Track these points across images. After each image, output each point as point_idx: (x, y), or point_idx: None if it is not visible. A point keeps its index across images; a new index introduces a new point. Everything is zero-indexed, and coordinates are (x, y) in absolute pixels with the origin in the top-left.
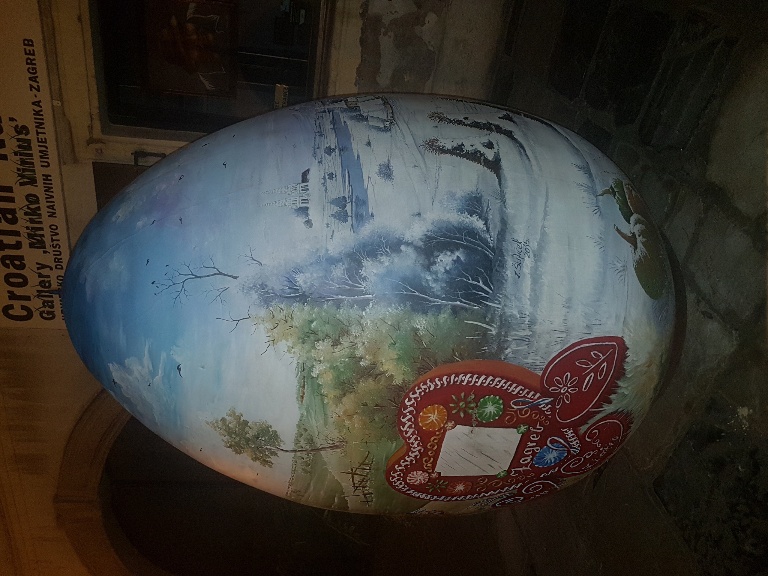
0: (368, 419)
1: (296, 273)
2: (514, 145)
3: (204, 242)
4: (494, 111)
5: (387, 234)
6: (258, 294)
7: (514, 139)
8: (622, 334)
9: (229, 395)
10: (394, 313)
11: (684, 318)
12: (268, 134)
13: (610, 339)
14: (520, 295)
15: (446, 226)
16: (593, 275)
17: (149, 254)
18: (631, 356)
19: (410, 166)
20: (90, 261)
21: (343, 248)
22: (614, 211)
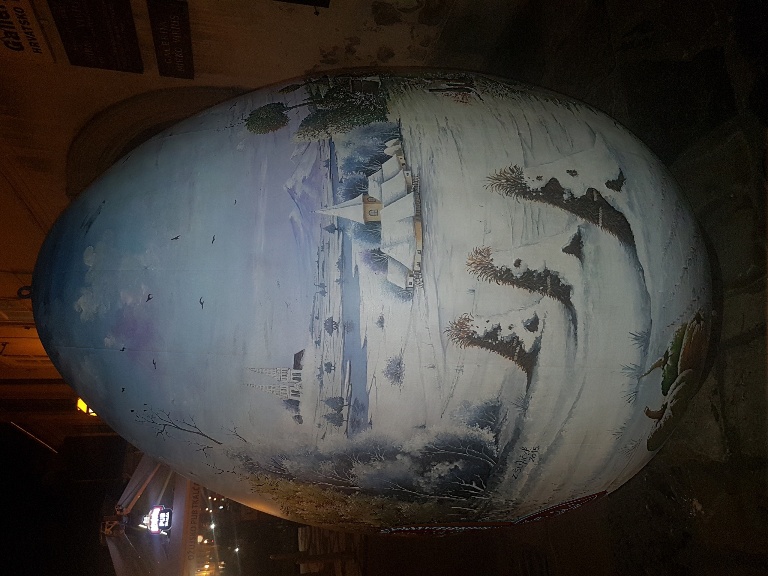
0: None
1: (282, 458)
2: (565, 319)
3: (183, 400)
4: (563, 226)
5: (384, 443)
6: (243, 462)
7: (569, 306)
8: (607, 489)
9: None
10: (379, 500)
11: (694, 393)
12: (256, 263)
13: (592, 495)
14: (512, 490)
15: (451, 439)
16: (597, 463)
17: (123, 383)
18: None
19: (426, 366)
20: (59, 342)
21: (334, 450)
22: (654, 388)
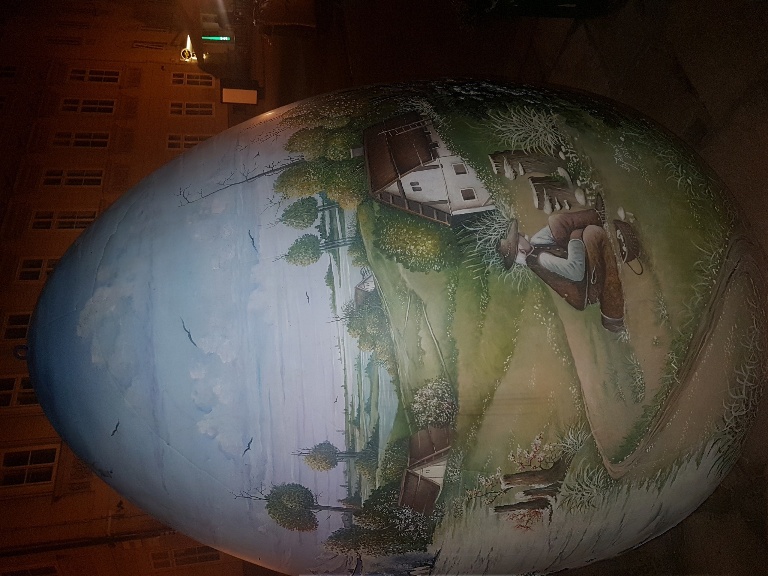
0: None
1: None
2: None
3: None
4: None
5: None
6: None
7: None
8: None
9: None
10: None
11: None
12: None
13: None
14: None
15: None
16: None
17: None
18: None
19: None
20: None
21: None
22: None
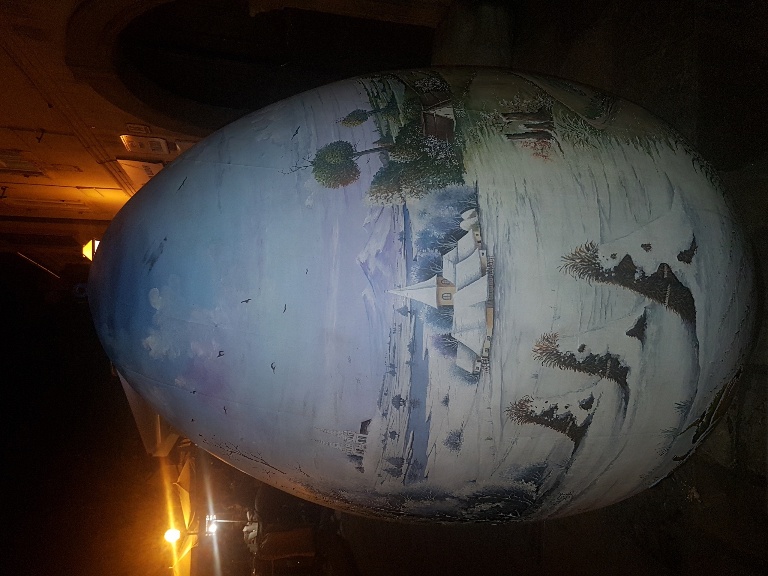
0: None
1: (342, 491)
2: (618, 397)
3: (252, 441)
4: (630, 309)
5: (436, 490)
6: (304, 487)
7: (624, 386)
8: None
9: None
10: None
11: None
12: (328, 339)
13: None
14: None
15: (497, 490)
16: (621, 494)
17: (193, 416)
18: None
19: (484, 438)
20: (126, 365)
21: (390, 491)
22: (686, 441)
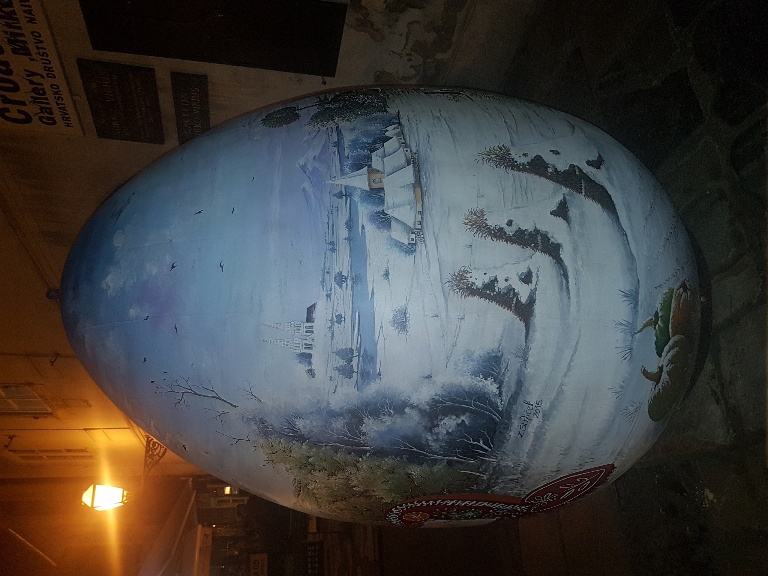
0: (357, 513)
1: (296, 418)
2: (557, 273)
3: (202, 363)
4: (549, 193)
5: (392, 395)
6: (257, 426)
7: (559, 262)
8: (613, 461)
9: (232, 474)
10: (390, 462)
11: (693, 381)
12: (272, 227)
13: (600, 467)
14: (519, 451)
15: (456, 390)
16: (600, 424)
17: (146, 352)
18: (617, 470)
19: (429, 315)
20: (85, 323)
21: (345, 404)
22: (648, 347)
